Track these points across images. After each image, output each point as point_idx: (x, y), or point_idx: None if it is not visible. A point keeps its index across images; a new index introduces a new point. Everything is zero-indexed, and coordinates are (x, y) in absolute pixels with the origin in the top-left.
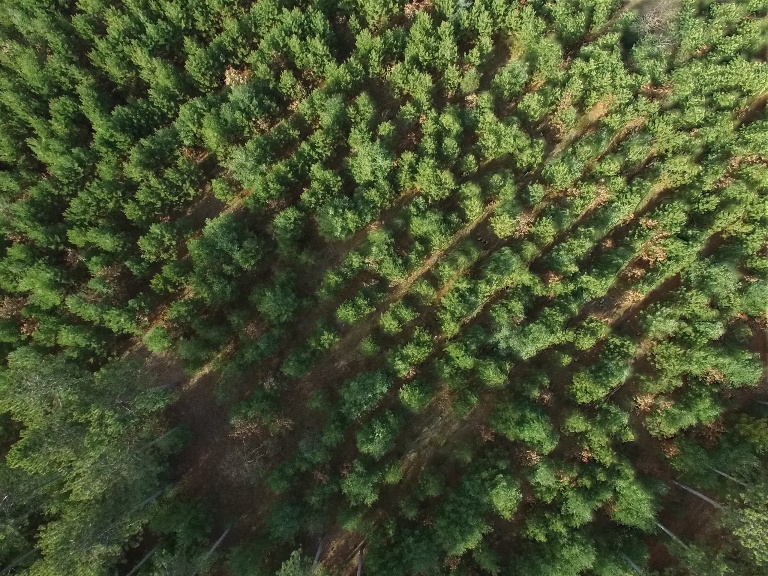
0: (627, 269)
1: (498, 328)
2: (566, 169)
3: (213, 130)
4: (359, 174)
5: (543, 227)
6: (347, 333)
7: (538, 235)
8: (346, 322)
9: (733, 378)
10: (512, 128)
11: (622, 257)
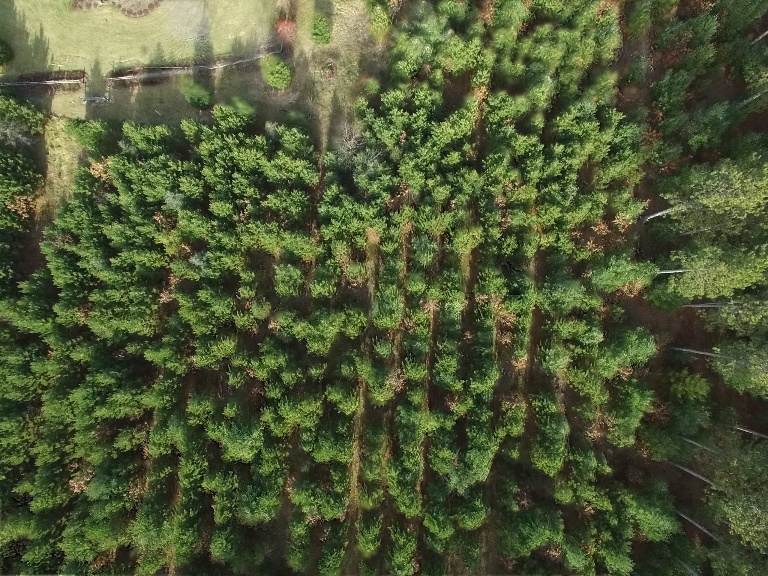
0: (498, 334)
1: (446, 480)
2: (388, 318)
3: (101, 534)
4: (243, 457)
5: (411, 371)
6: (344, 572)
7: (413, 380)
8: (335, 569)
9: (638, 357)
10: (322, 324)
11: (485, 344)
